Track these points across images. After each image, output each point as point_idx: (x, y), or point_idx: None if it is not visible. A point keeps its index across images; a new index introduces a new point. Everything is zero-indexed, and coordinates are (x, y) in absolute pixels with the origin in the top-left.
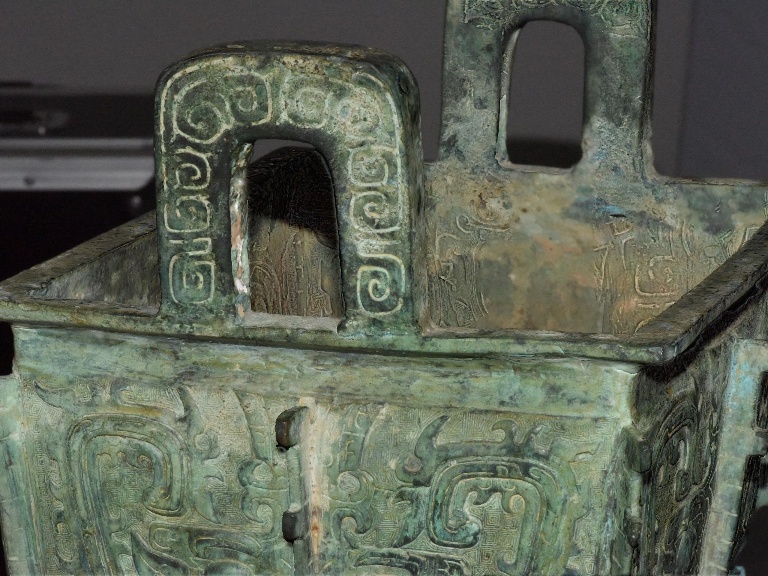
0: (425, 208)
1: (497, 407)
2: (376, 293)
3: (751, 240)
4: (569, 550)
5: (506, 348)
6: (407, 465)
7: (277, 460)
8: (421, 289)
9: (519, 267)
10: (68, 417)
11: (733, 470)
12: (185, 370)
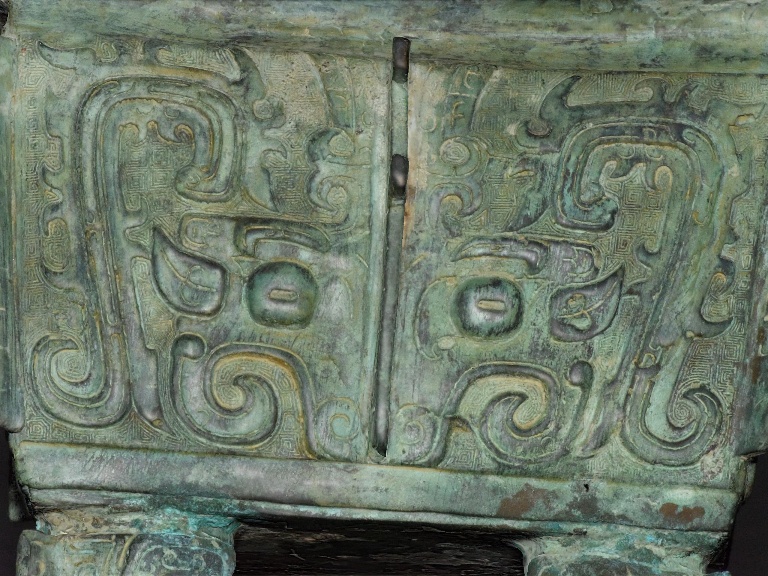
0: None
1: (638, 69)
2: None
3: None
4: (725, 235)
5: None
6: (530, 130)
7: (362, 127)
8: None
9: None
10: (84, 80)
11: None
12: (238, 35)
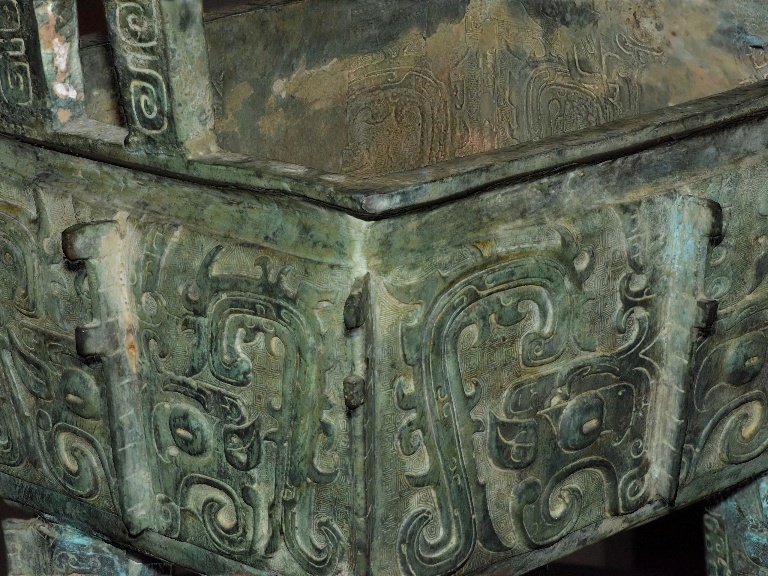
0: (589, 23)
1: (262, 242)
2: (147, 109)
3: (744, 86)
4: (322, 402)
5: (248, 180)
6: (191, 292)
7: None
8: (193, 109)
9: (676, 95)
10: None
11: (679, 341)
12: (43, 171)
